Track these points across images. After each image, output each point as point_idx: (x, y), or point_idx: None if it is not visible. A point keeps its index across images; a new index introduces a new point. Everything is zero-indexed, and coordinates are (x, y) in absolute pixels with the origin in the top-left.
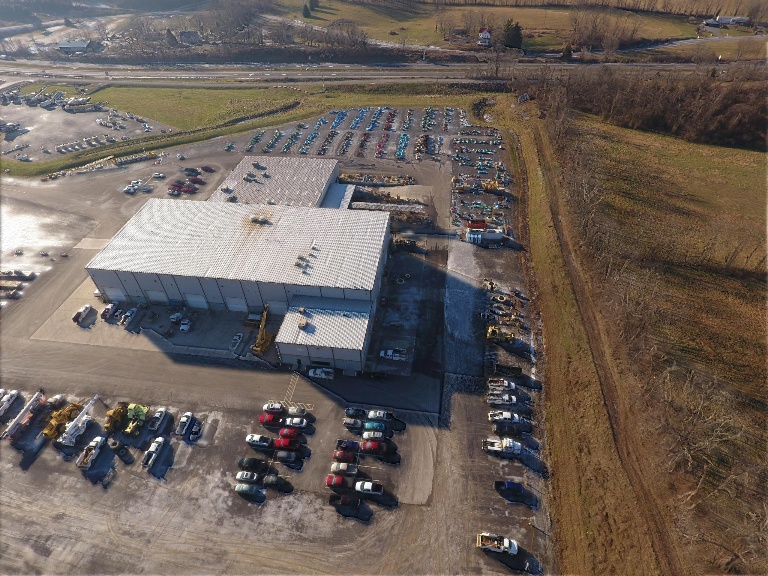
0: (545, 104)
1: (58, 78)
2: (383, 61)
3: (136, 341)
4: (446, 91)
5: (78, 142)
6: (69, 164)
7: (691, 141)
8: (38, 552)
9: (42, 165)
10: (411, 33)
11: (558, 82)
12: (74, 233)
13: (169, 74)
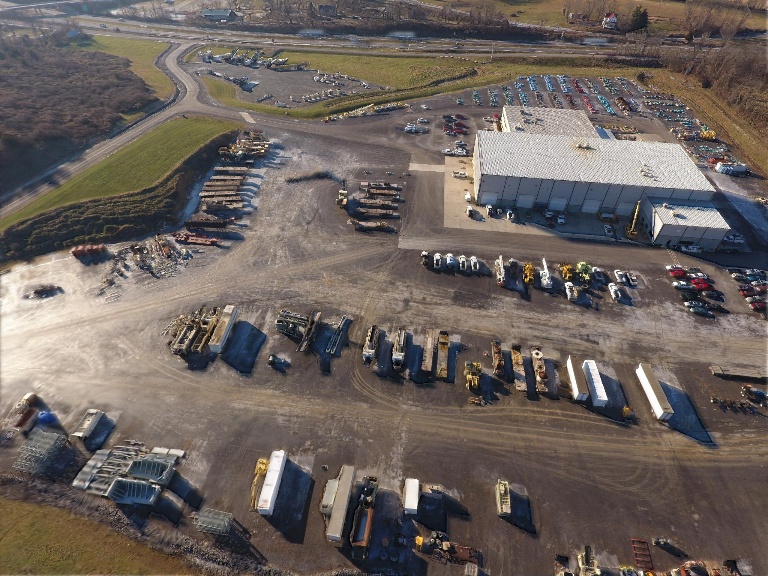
0: (704, 77)
1: (227, 42)
2: (523, 39)
3: (529, 230)
4: (603, 65)
5: None
6: (335, 110)
7: None
8: (589, 342)
9: (309, 110)
10: (531, 16)
11: (701, 60)
12: (397, 160)
13: (330, 43)
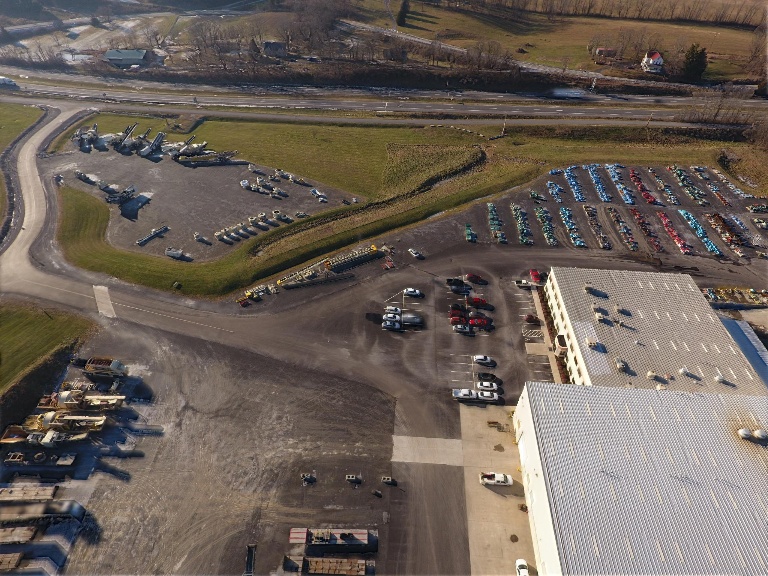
0: None
1: (129, 105)
2: (540, 90)
3: None
4: (662, 138)
5: (243, 224)
6: (263, 270)
7: None
8: None
9: (219, 271)
10: (543, 51)
11: None
12: (369, 424)
13: (276, 102)
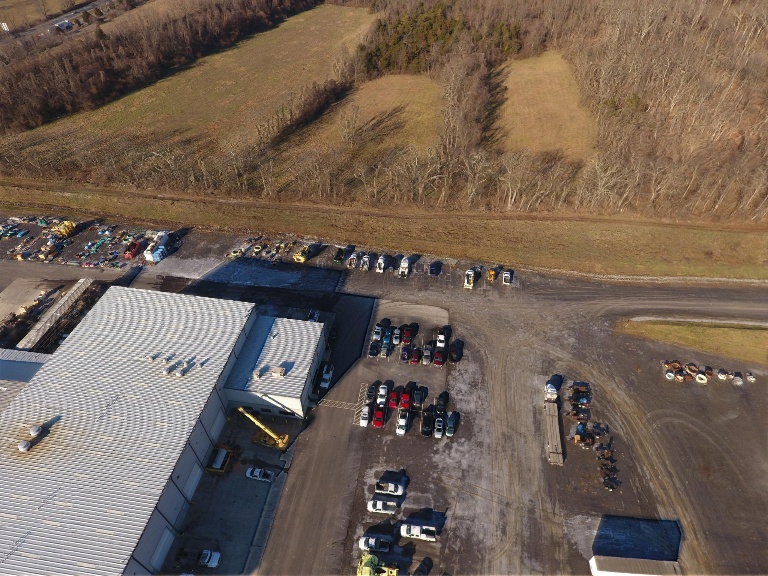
0: None
1: None
2: None
3: None
4: None
5: None
6: None
7: (94, 109)
8: None
9: None
10: None
11: None
12: None
13: None
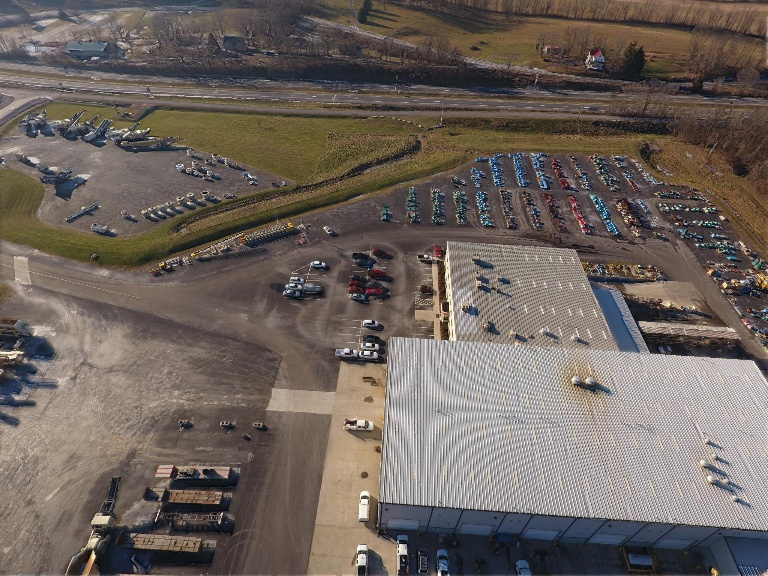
0: (734, 156)
1: (84, 94)
2: (486, 85)
3: None
4: (592, 130)
5: (171, 203)
6: (180, 244)
7: None
8: None
9: (139, 244)
10: (496, 49)
11: (722, 124)
12: (252, 378)
13: (228, 93)
